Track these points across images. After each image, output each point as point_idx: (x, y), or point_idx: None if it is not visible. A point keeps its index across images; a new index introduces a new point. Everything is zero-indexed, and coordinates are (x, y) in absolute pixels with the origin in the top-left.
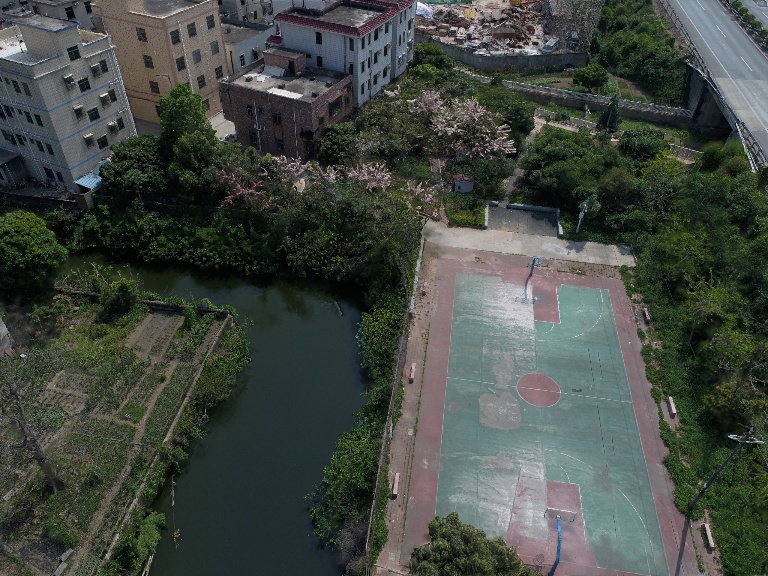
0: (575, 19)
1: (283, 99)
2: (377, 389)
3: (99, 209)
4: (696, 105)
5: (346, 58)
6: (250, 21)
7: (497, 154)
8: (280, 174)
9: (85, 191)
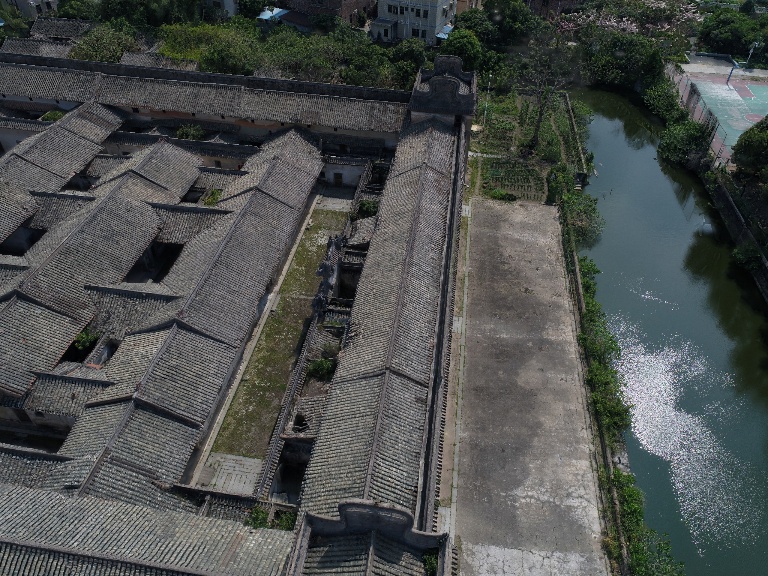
0: None
1: None
2: (677, 112)
3: None
4: None
5: None
6: None
7: (689, 21)
8: None
9: (438, 43)
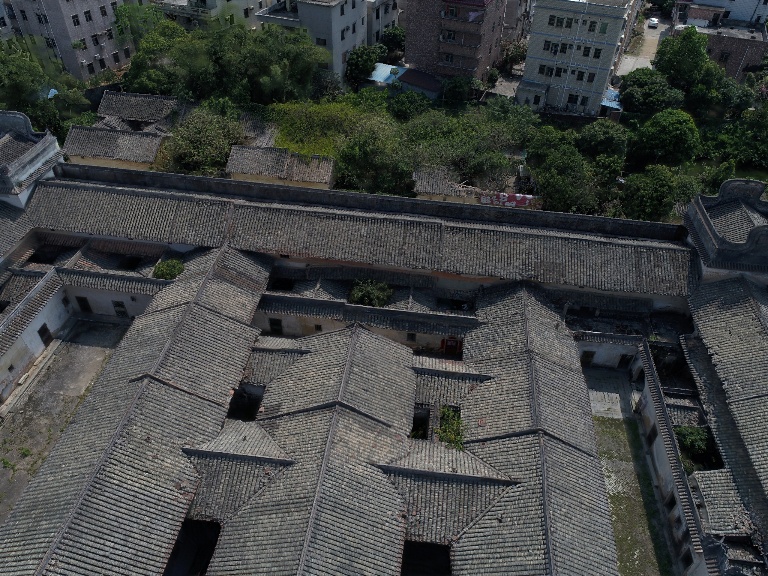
0: None
1: (740, 40)
2: None
3: (632, 123)
4: None
5: (756, 11)
6: None
7: None
8: None
9: (601, 112)
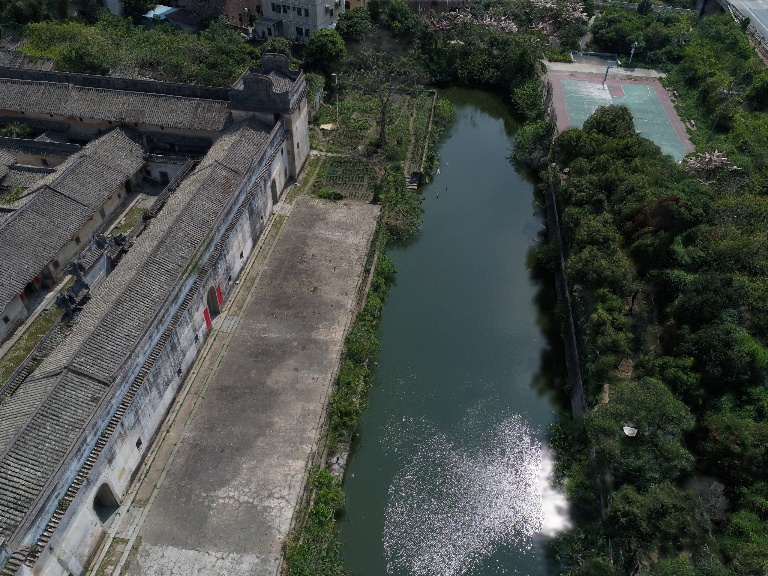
0: None
1: None
2: None
3: None
4: (701, 6)
5: None
6: None
7: (577, 21)
8: None
9: None
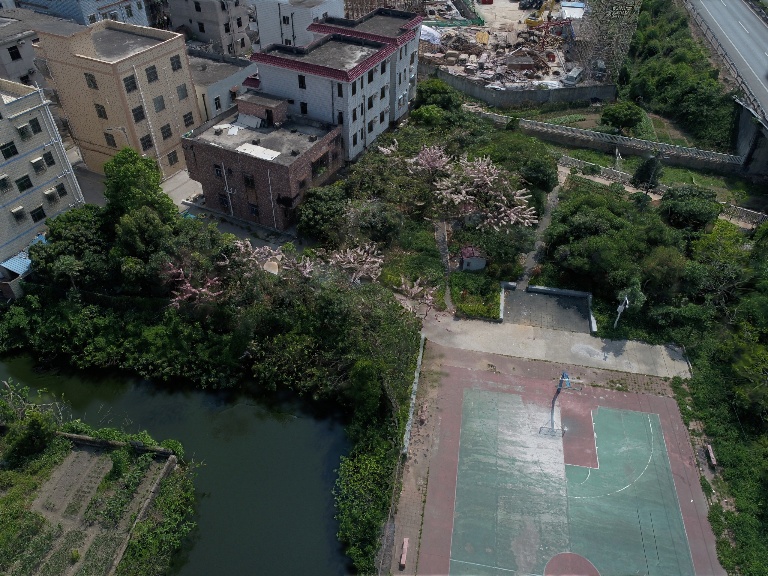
0: (602, 47)
1: (255, 160)
2: None
3: (27, 301)
4: (748, 151)
5: (334, 105)
6: (236, 50)
7: (515, 226)
8: (243, 265)
9: (16, 274)
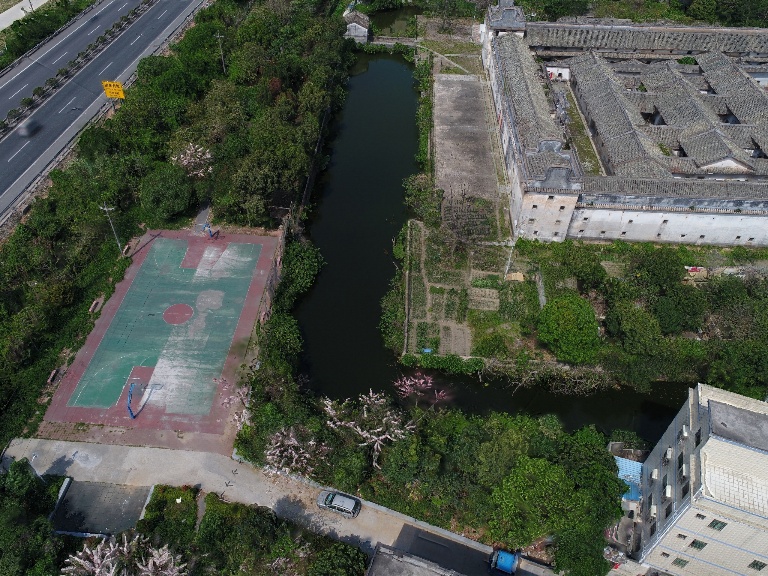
0: None
1: None
2: (288, 292)
3: None
4: None
5: None
6: None
7: None
8: None
9: None
